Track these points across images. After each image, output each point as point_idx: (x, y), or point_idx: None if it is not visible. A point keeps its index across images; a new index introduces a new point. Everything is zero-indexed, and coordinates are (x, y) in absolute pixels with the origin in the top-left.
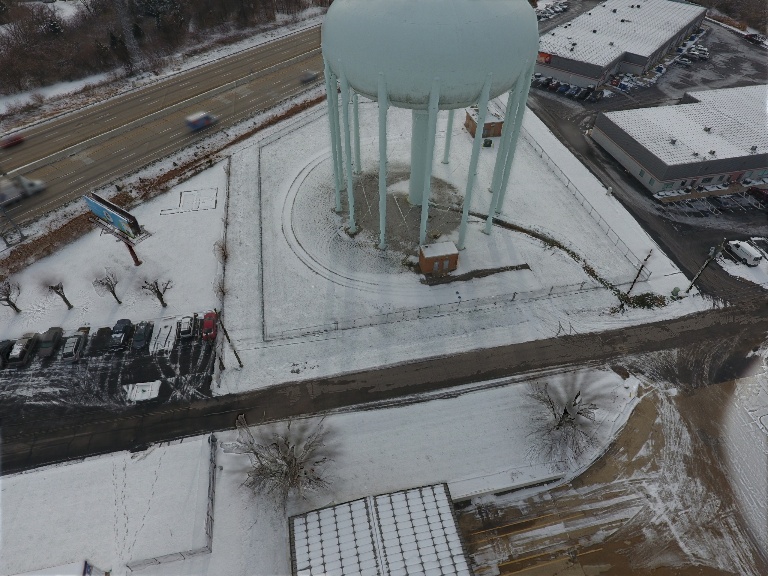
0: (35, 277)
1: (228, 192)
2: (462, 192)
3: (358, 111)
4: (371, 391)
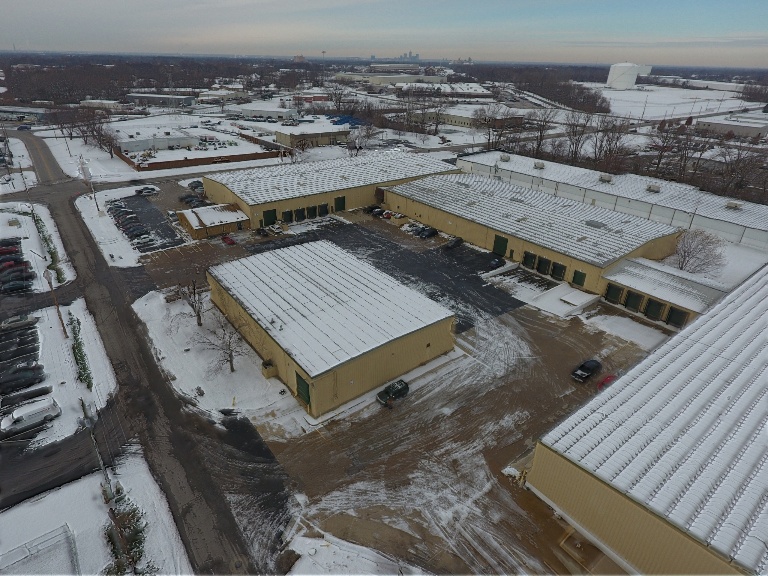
0: None
1: None
2: None
3: None
4: None
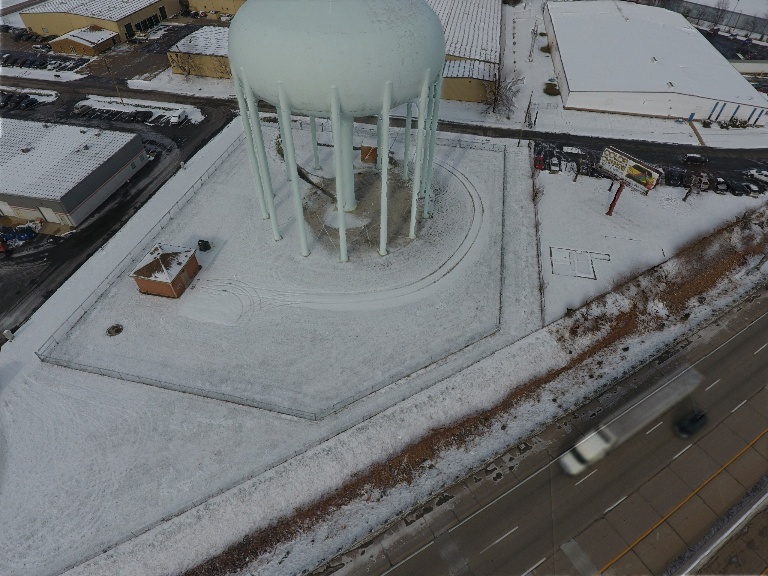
0: (696, 225)
1: (539, 261)
2: None
3: (306, 384)
4: (451, 126)
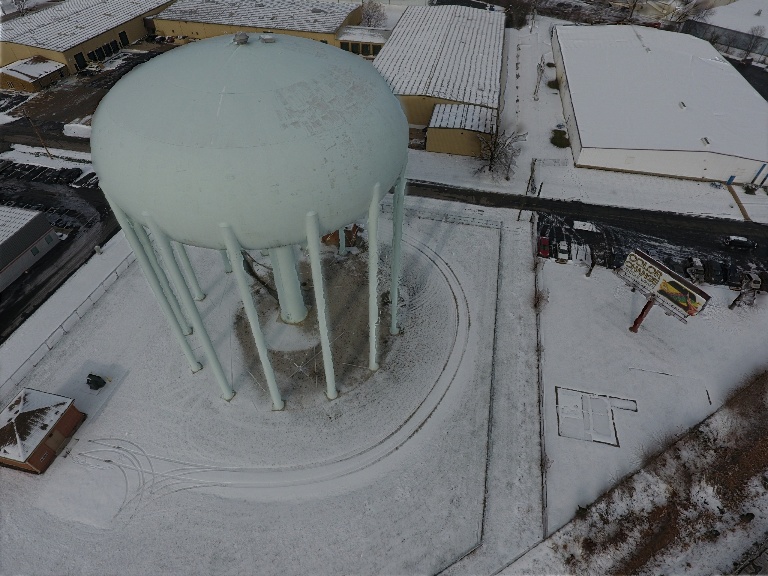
0: (749, 349)
1: (540, 413)
2: (235, 307)
3: None
4: (437, 190)
